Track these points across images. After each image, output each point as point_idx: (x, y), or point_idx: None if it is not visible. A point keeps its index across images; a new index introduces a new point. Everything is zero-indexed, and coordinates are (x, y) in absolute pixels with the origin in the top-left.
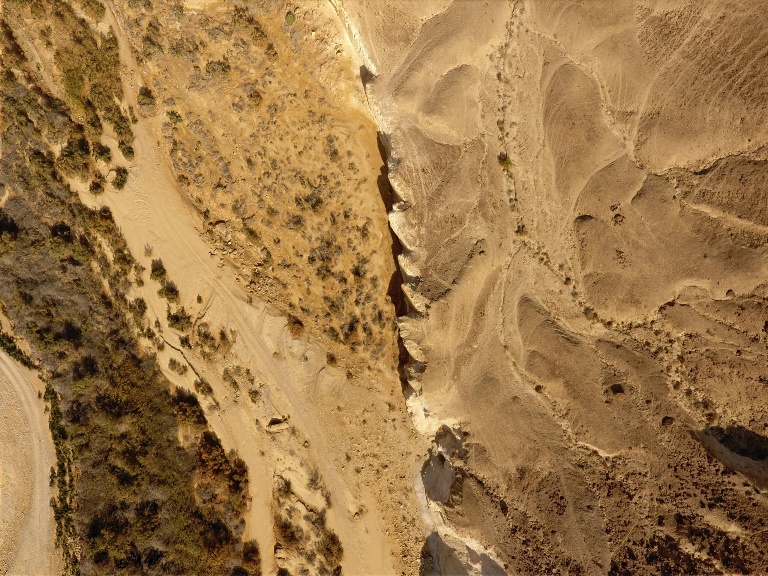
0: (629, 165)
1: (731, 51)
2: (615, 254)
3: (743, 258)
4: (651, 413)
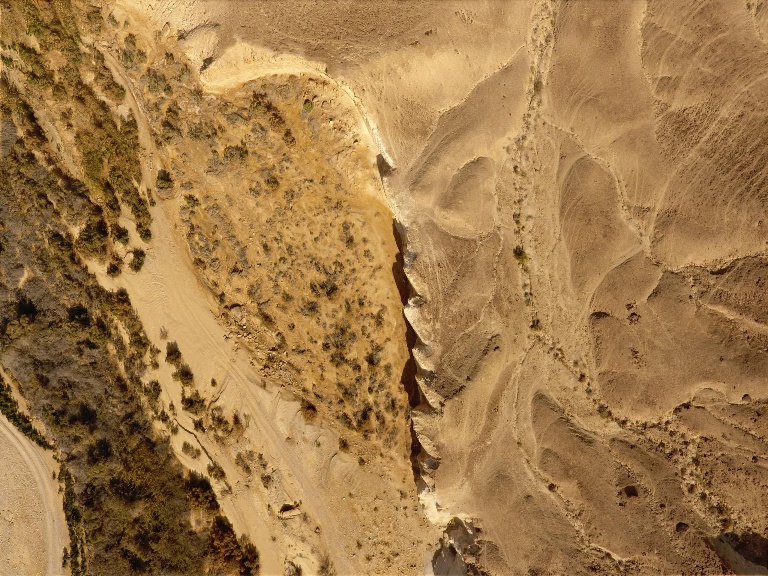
0: (645, 262)
1: (749, 151)
2: (630, 354)
3: (760, 363)
4: (665, 518)
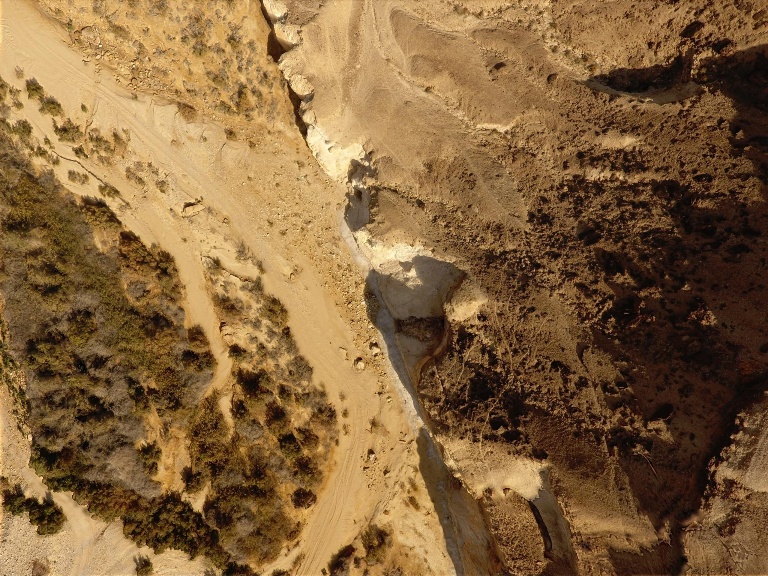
0: None
1: None
2: None
3: None
4: (536, 77)
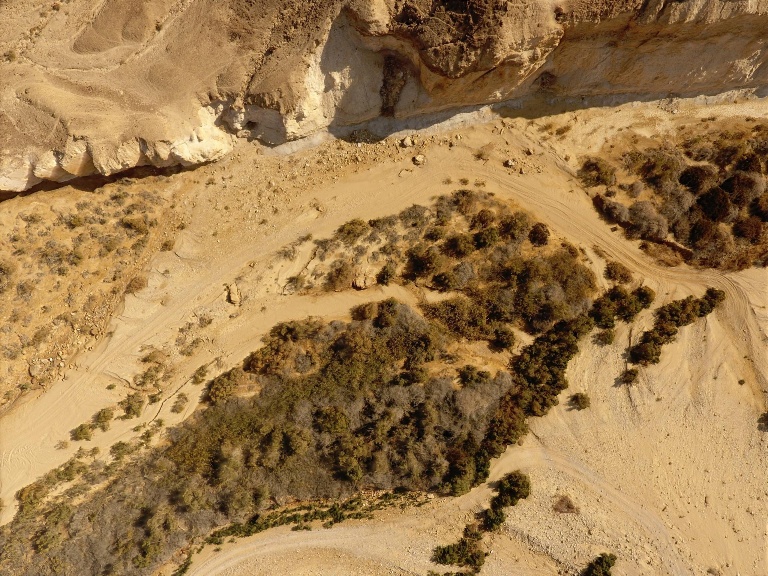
0: None
1: None
2: None
3: None
4: None
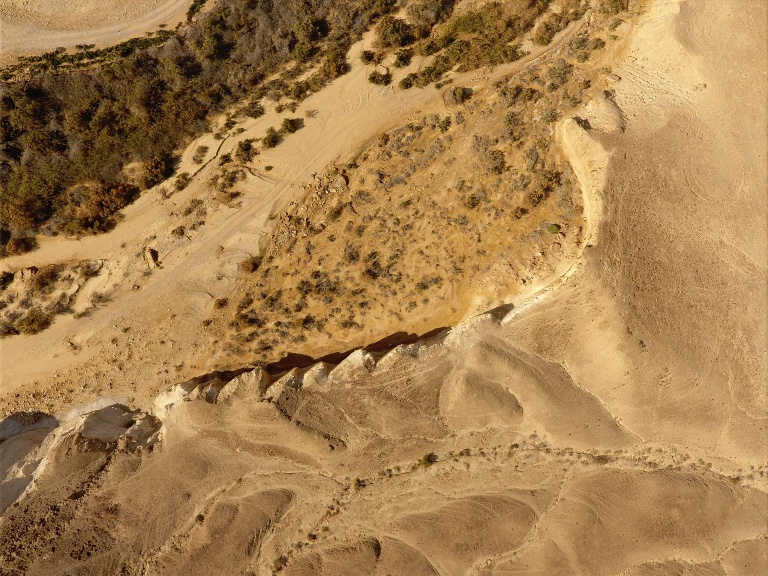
0: None
1: None
2: None
3: None
4: None
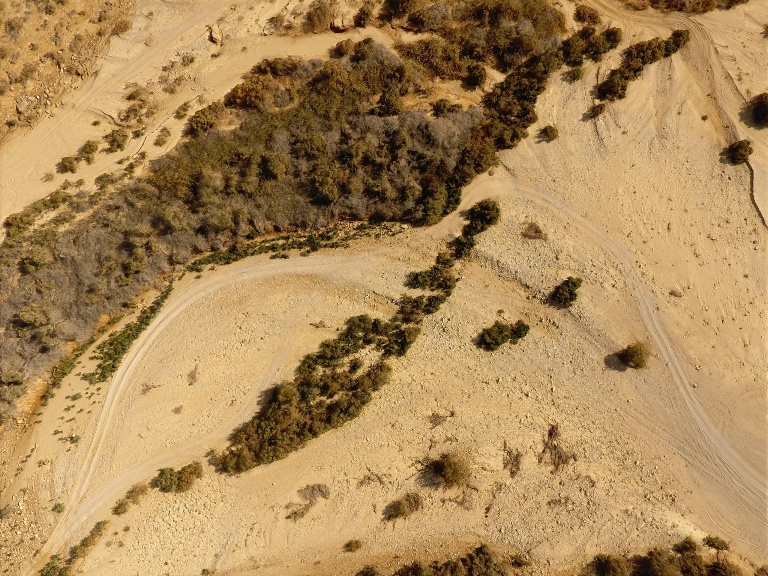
0: None
1: None
2: None
3: None
4: None
